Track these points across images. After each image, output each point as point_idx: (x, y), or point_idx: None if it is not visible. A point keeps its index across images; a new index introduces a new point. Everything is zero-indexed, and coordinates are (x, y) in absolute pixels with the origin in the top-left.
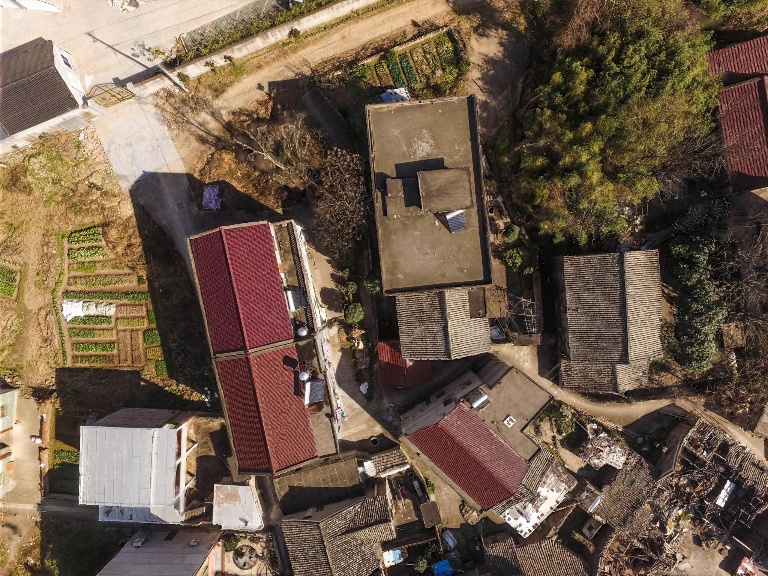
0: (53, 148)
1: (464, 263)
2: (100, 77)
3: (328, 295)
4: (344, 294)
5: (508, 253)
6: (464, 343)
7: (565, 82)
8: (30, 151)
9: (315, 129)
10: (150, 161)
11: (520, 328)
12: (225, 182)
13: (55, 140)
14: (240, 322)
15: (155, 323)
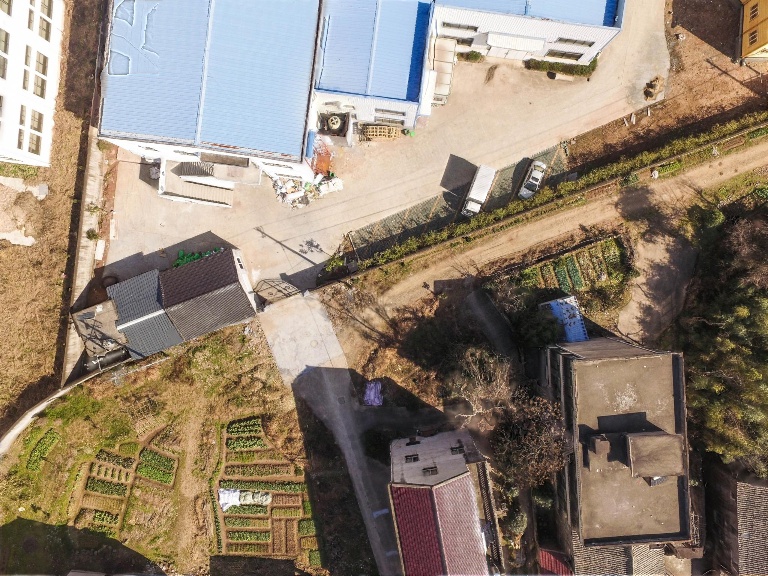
0: (218, 341)
1: (662, 516)
2: (267, 272)
3: None
4: (502, 493)
5: None
6: (644, 575)
7: (749, 316)
8: (194, 343)
9: (499, 354)
10: (313, 356)
11: None
12: (387, 378)
13: (220, 333)
14: None
15: (311, 514)
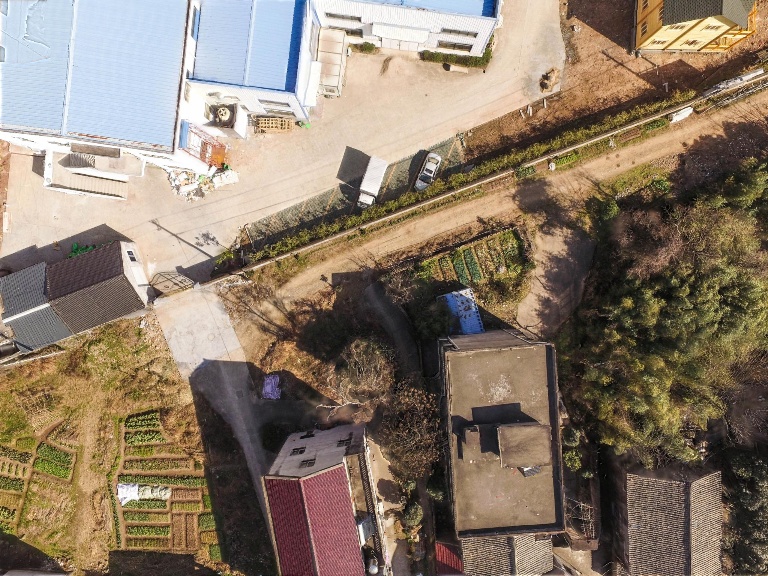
0: (114, 335)
1: (537, 507)
2: (163, 265)
3: (385, 487)
4: (401, 486)
5: (568, 455)
6: (529, 567)
7: (635, 307)
8: (90, 337)
9: (385, 346)
10: (211, 349)
11: (578, 531)
12: (285, 371)
13: (116, 327)
14: (316, 572)
15: (210, 508)
